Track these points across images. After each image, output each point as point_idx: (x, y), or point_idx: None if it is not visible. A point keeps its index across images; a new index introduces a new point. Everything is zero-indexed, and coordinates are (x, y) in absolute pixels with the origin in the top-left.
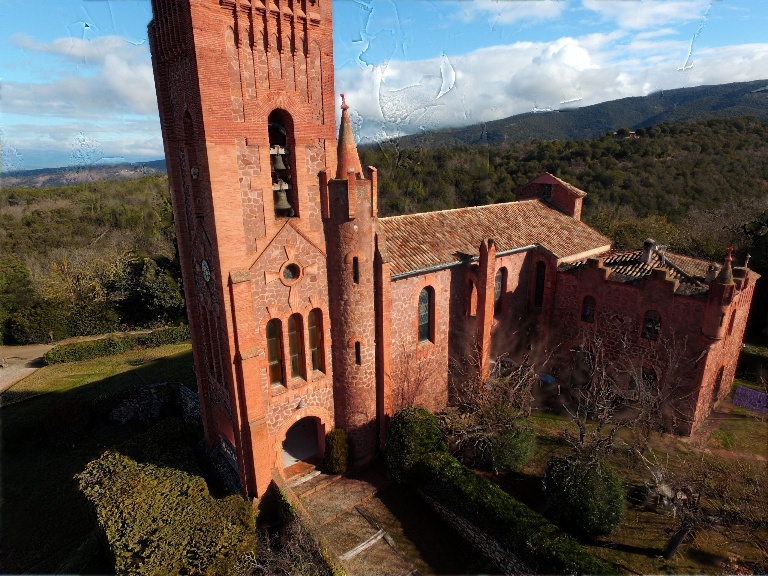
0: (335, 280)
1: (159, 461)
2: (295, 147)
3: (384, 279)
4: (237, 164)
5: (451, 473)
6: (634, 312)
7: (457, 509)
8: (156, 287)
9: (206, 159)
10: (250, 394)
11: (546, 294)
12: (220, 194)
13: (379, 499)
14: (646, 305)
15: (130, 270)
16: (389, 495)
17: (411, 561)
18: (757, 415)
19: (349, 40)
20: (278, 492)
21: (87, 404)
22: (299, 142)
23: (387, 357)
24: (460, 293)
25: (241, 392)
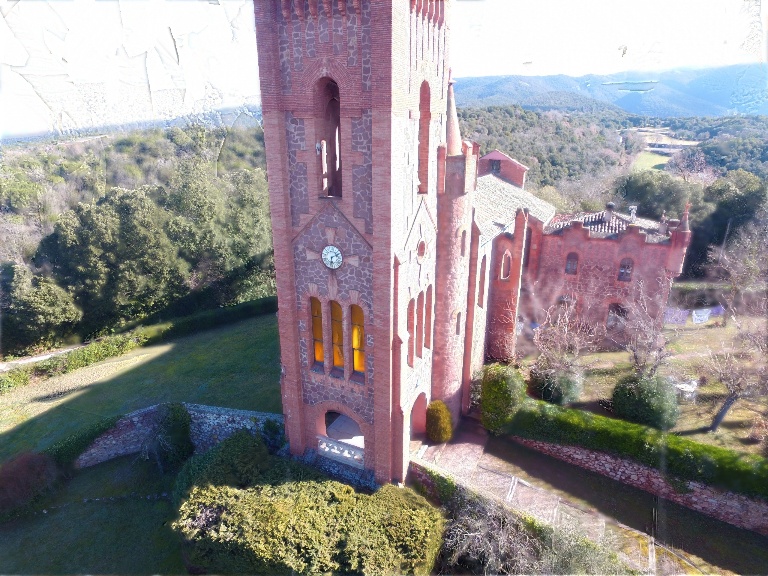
0: (443, 255)
1: (270, 480)
2: (430, 121)
3: (479, 250)
4: (404, 138)
5: (552, 413)
6: (612, 261)
7: (563, 441)
8: (39, 300)
9: (387, 132)
10: (402, 378)
11: (532, 255)
12: (395, 170)
13: (489, 454)
14: (622, 254)
15: None
16: (493, 448)
17: (552, 493)
18: (678, 327)
19: (205, 2)
20: (419, 471)
21: (45, 456)
22: (432, 116)
23: (474, 324)
24: (493, 260)
25: (394, 378)
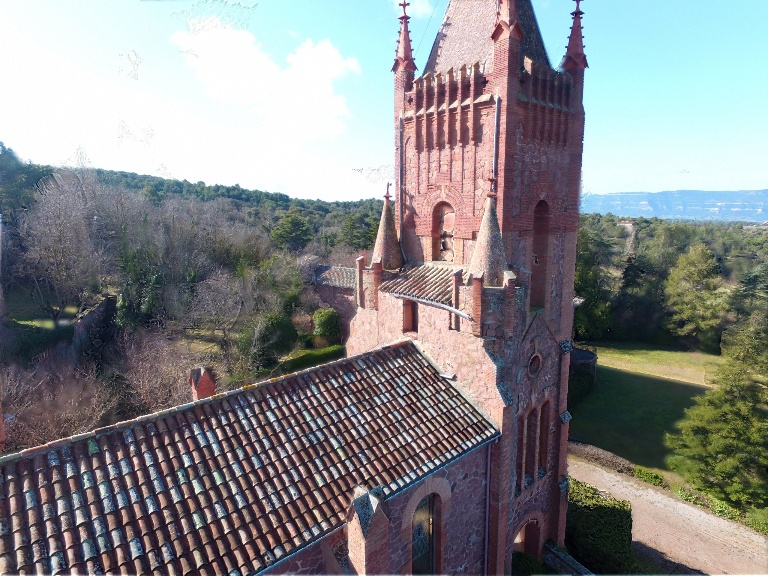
0: None
1: None
2: None
3: None
4: None
5: None
6: None
7: None
8: None
9: None
10: None
11: None
12: None
13: None
14: None
15: None
16: None
17: None
18: None
19: None
20: None
21: None
22: None
23: None
24: None
25: None
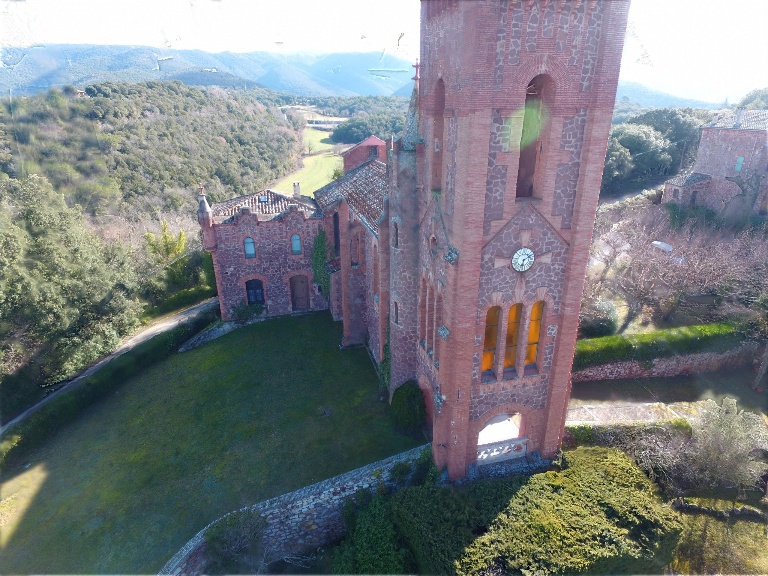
0: None
1: (496, 508)
2: None
3: None
4: None
5: None
6: None
7: (582, 367)
8: None
9: (606, 131)
10: None
11: None
12: None
13: None
14: None
15: None
16: None
17: (606, 405)
18: None
19: None
20: None
21: None
22: None
23: None
24: None
25: None
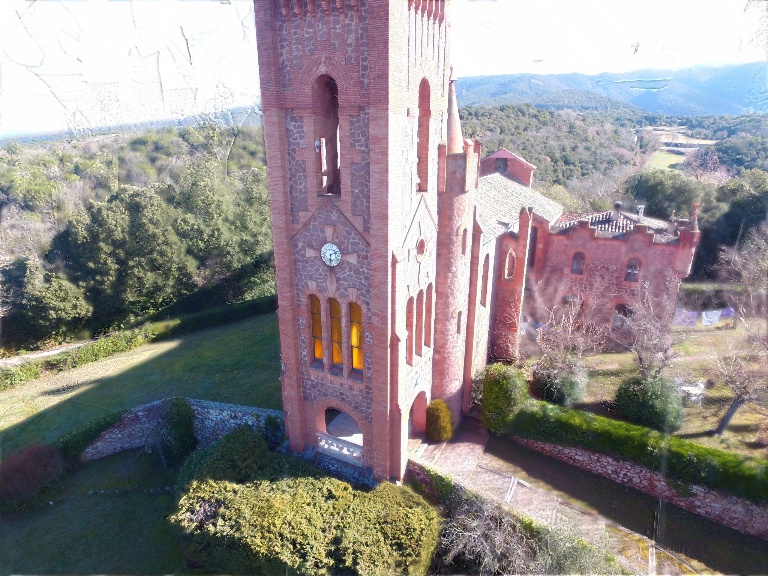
0: (444, 253)
1: (269, 475)
2: (429, 119)
3: (480, 249)
4: (402, 136)
5: (554, 413)
6: (619, 261)
7: (564, 442)
8: (51, 296)
9: (384, 130)
10: (400, 376)
11: (538, 255)
12: (392, 168)
13: (489, 454)
14: (629, 254)
15: (3, 278)
16: (494, 448)
17: (551, 494)
18: (687, 329)
19: (217, 1)
20: (418, 470)
21: (53, 448)
22: (432, 114)
23: None
24: (497, 259)
25: (392, 376)
